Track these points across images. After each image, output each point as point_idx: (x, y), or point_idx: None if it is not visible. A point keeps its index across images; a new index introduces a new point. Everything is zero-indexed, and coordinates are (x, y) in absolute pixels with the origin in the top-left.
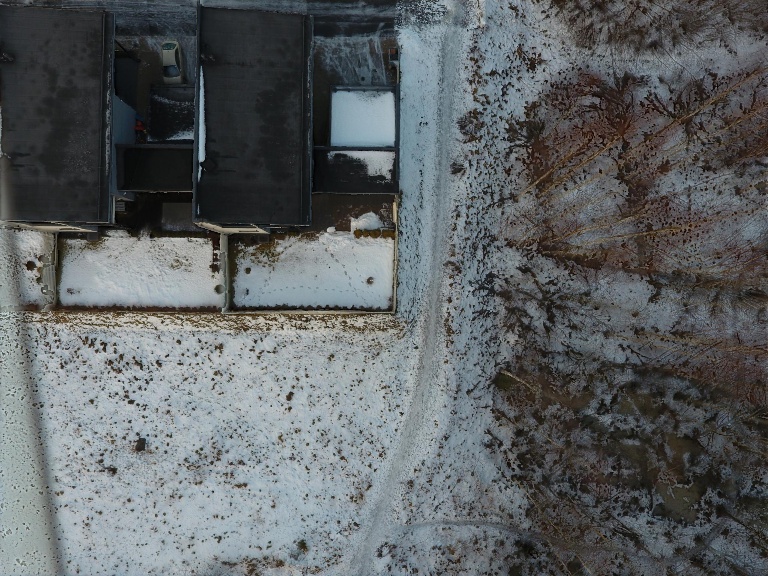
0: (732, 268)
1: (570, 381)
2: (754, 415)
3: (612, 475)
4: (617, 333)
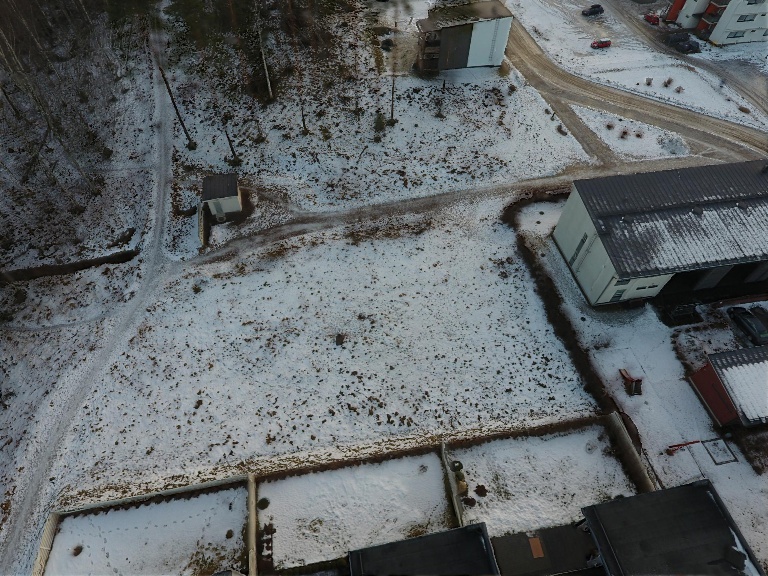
0: None
1: None
2: None
3: None
4: None
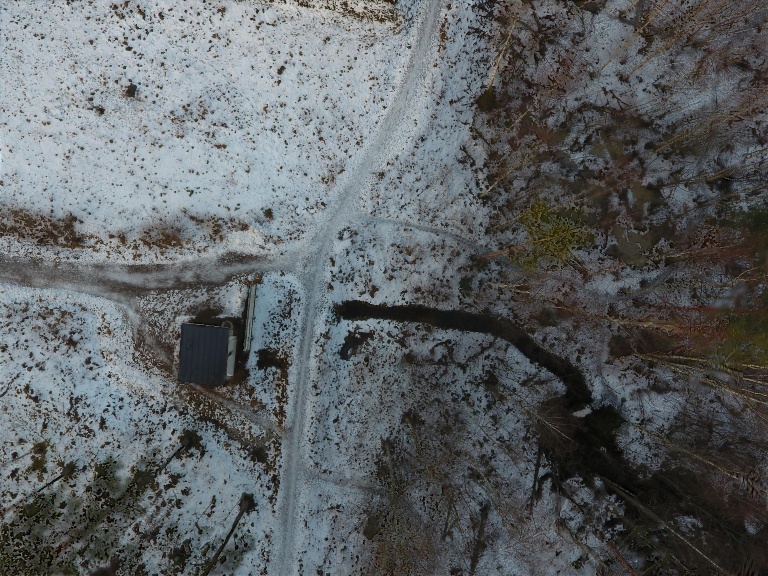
0: (723, 35)
1: (550, 115)
2: (718, 175)
3: (573, 210)
4: (602, 76)
